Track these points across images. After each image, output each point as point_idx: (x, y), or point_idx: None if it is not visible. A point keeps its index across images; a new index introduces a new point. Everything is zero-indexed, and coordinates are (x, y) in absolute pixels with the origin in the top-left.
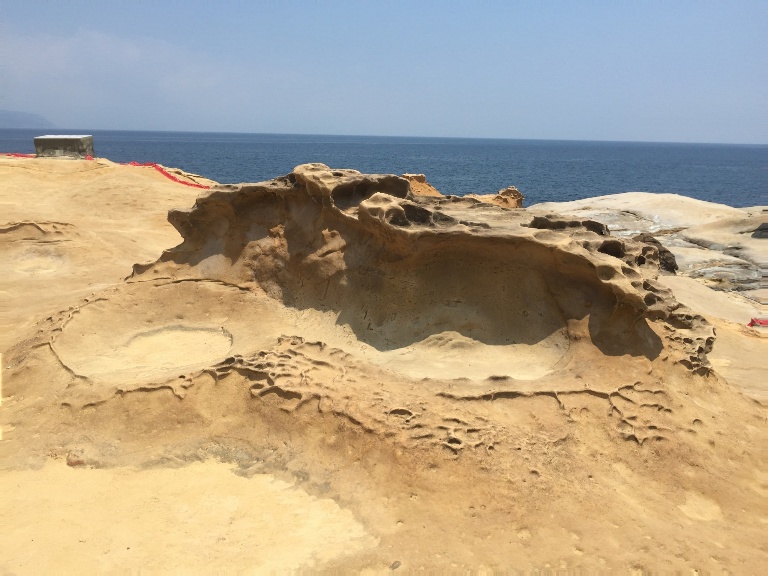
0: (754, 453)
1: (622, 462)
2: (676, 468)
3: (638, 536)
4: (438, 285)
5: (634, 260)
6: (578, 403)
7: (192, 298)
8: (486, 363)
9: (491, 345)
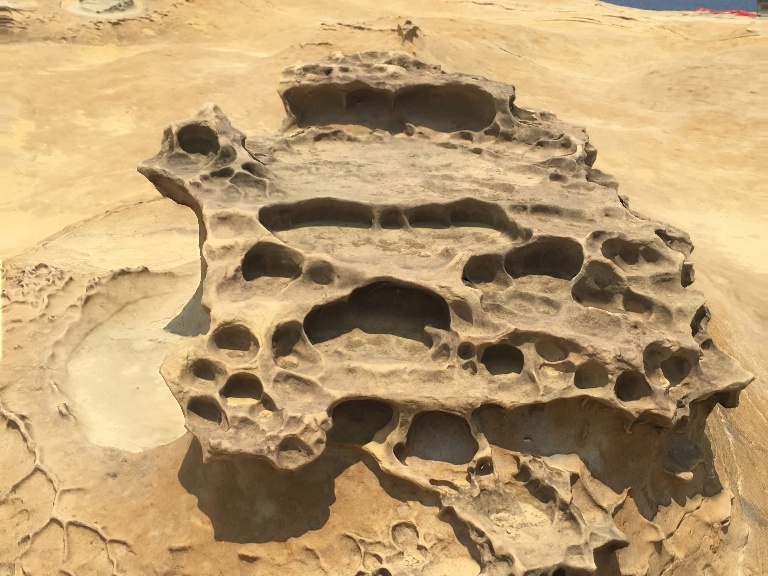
0: None
1: None
2: None
3: None
4: None
5: (463, 350)
6: (36, 500)
7: None
8: (158, 399)
9: None
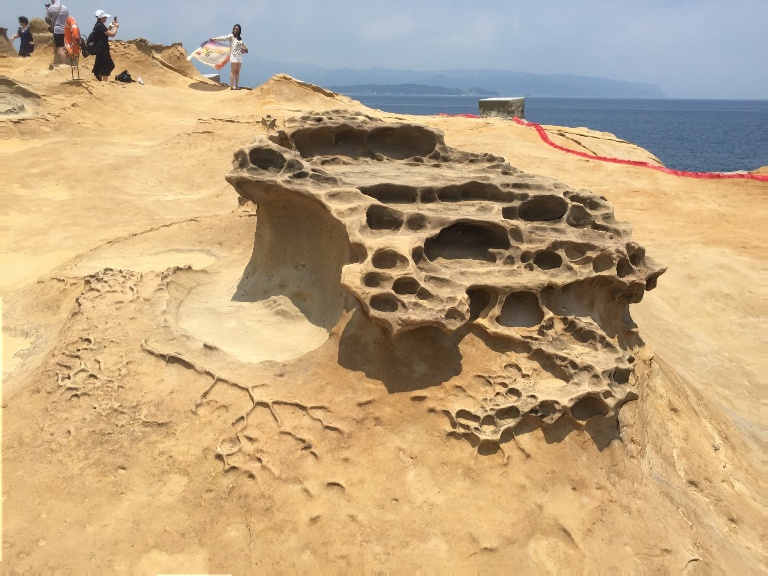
0: (359, 567)
1: (187, 478)
2: (225, 517)
3: (33, 533)
4: (291, 243)
5: (523, 256)
6: (228, 398)
7: (243, 230)
8: (267, 336)
9: (310, 322)
